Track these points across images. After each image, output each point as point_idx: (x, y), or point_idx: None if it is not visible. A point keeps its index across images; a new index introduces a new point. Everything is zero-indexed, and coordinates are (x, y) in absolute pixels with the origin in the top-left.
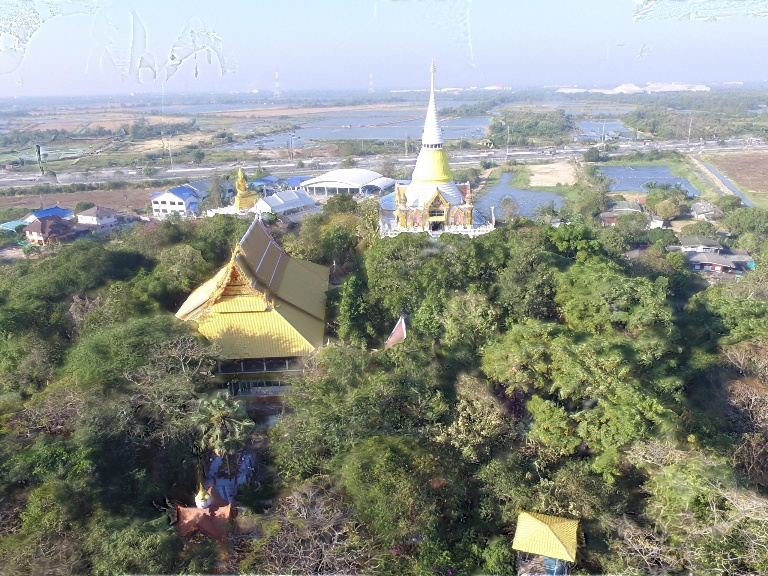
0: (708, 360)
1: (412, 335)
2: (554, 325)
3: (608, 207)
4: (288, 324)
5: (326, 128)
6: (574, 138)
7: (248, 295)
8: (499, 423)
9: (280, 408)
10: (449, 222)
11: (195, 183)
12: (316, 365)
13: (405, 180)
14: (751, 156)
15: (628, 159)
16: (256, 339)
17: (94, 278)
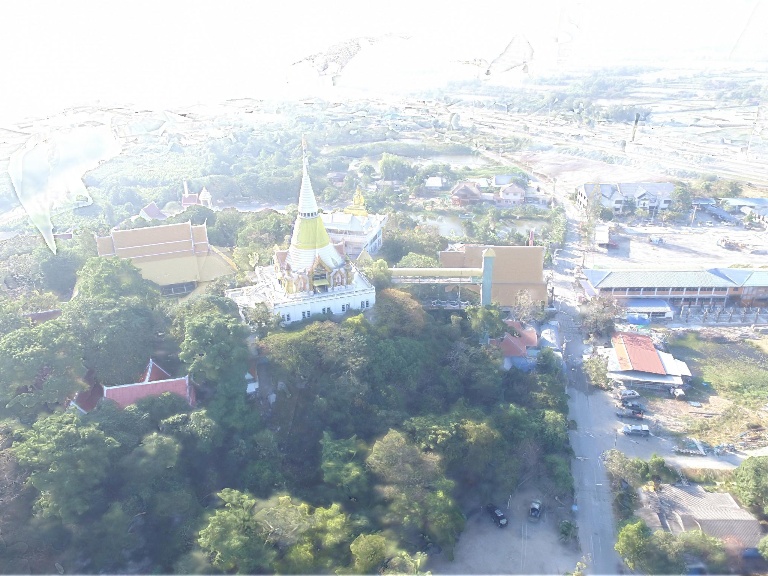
0: None
1: None
2: None
3: None
4: None
5: None
6: None
7: None
8: None
9: None
10: None
11: (628, 184)
12: None
13: None
14: None
15: None
16: None
17: None
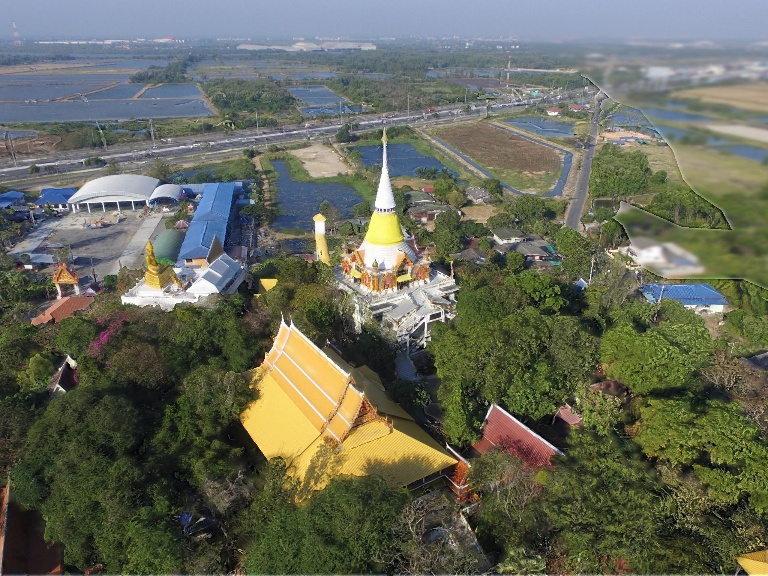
0: (698, 383)
1: (582, 437)
2: (674, 403)
3: (405, 199)
4: (415, 440)
5: (3, 104)
6: (313, 115)
7: (368, 422)
8: (699, 498)
9: (438, 522)
10: (412, 279)
11: None
12: (532, 489)
13: (188, 184)
14: (463, 128)
15: (374, 138)
16: (398, 465)
17: (132, 436)
